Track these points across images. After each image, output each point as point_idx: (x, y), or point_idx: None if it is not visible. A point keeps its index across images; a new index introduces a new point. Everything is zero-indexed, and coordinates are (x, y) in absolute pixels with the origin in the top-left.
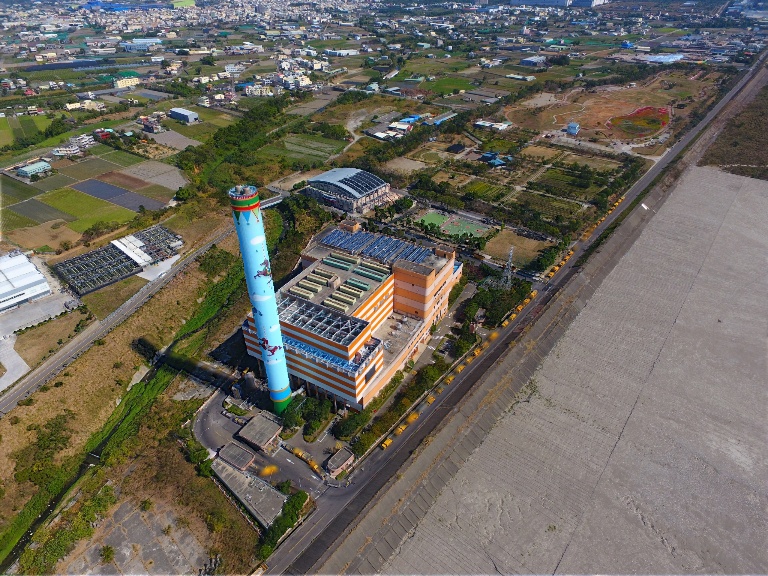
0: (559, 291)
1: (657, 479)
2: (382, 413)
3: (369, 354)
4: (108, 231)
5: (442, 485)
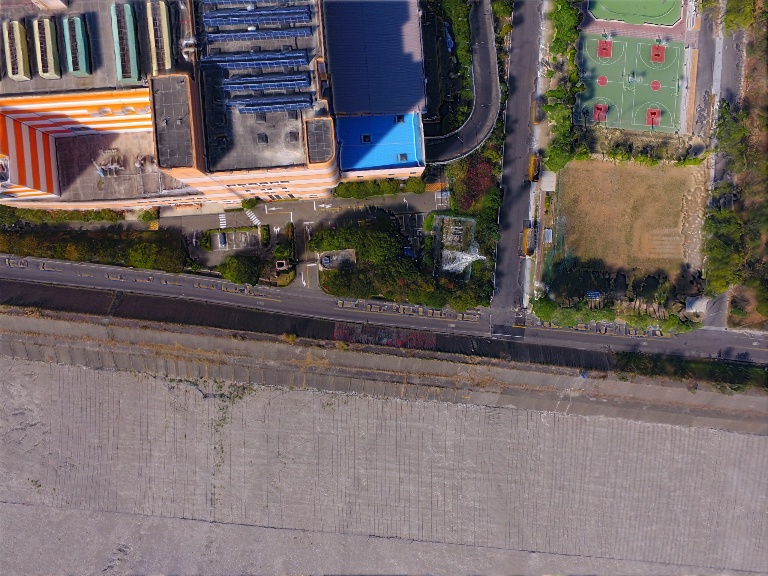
0: (491, 359)
1: (174, 574)
2: (56, 228)
3: None
4: None
5: (8, 354)
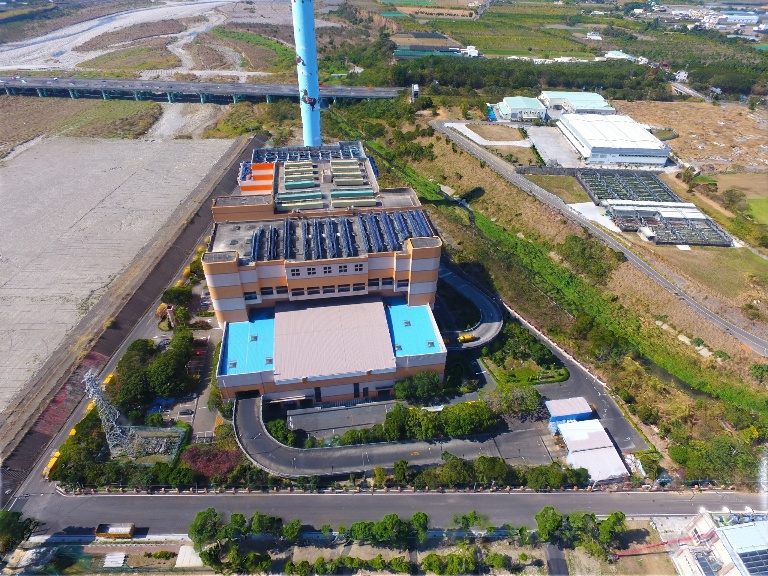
0: None
1: None
2: None
3: (245, 174)
4: (726, 205)
5: None
